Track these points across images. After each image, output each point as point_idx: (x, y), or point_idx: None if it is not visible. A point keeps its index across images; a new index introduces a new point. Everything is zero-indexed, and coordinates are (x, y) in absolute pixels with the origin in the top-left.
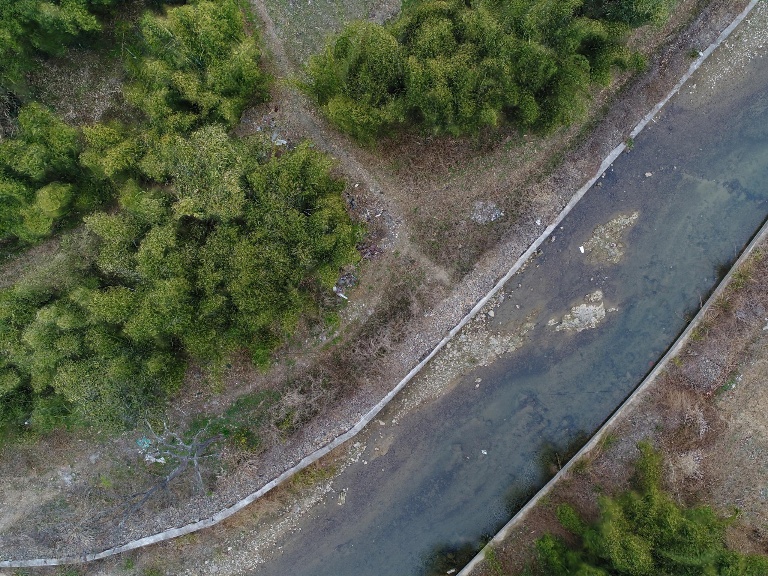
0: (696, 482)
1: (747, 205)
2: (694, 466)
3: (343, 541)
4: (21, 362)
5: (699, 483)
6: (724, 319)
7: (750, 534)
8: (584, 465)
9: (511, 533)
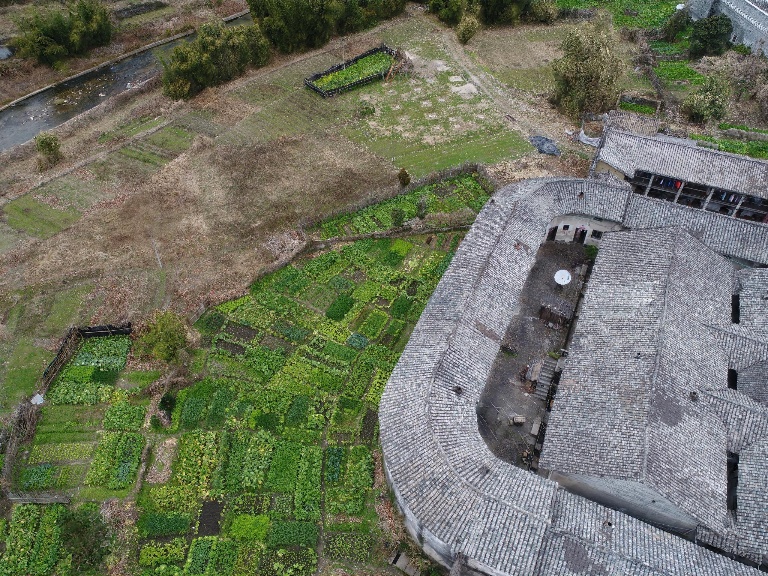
0: None
1: (249, 18)
2: None
3: None
4: None
5: None
6: None
7: None
8: None
9: None
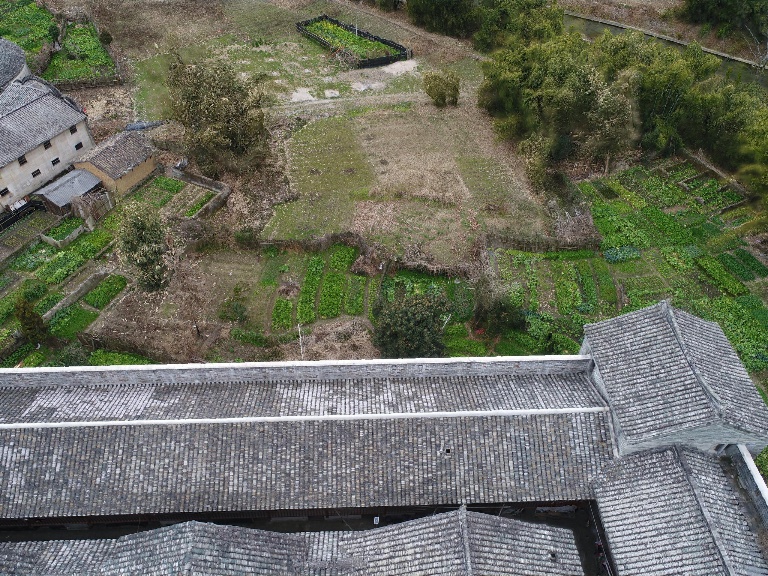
0: (669, 8)
1: None
2: (663, 10)
3: (766, 92)
4: (761, 112)
5: (669, 7)
6: (599, 8)
7: (681, 0)
8: (679, 35)
9: (723, 52)
